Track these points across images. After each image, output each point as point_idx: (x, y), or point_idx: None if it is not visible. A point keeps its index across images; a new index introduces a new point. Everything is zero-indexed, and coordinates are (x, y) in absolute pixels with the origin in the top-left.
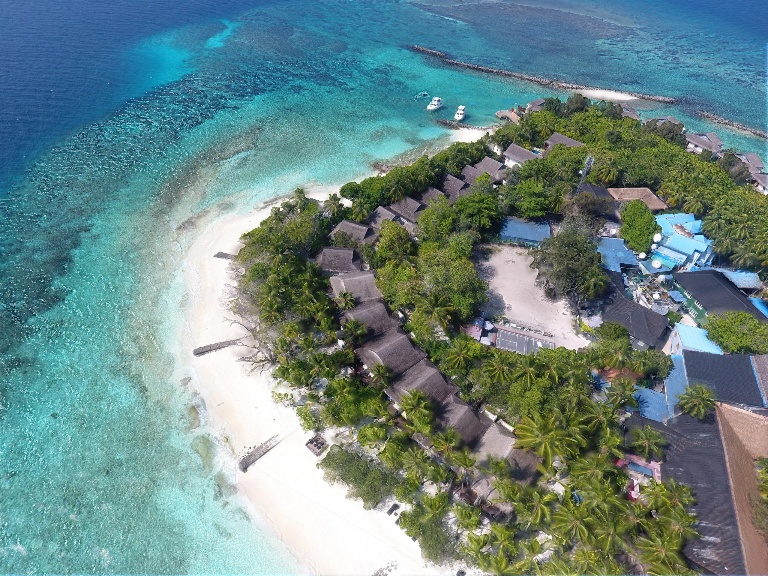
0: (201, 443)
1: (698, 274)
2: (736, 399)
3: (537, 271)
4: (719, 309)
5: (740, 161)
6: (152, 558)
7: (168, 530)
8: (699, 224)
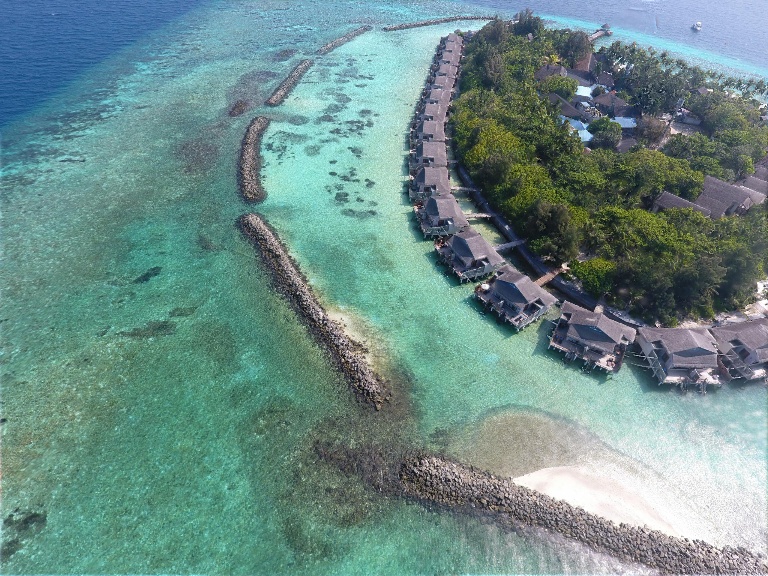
0: (764, 102)
1: None
2: None
3: None
4: None
5: (498, 158)
6: None
7: None
8: None
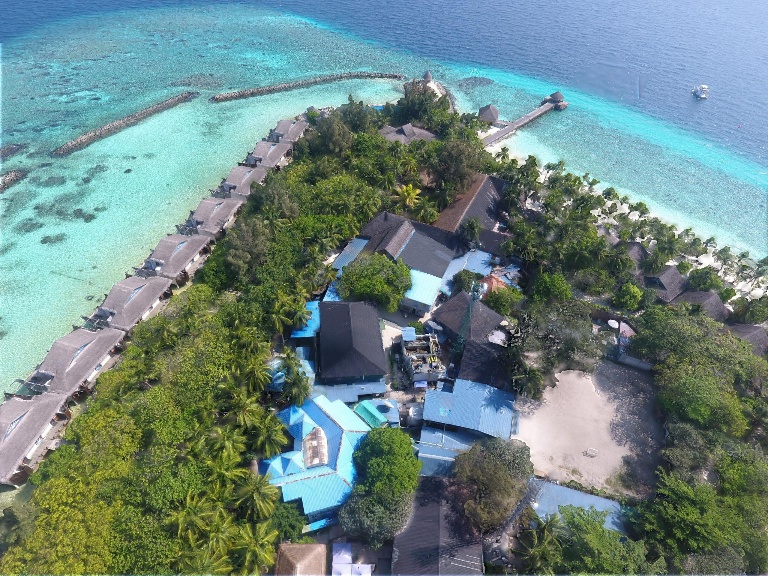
0: None
1: (366, 355)
2: (429, 240)
3: (550, 432)
4: (371, 316)
5: None
6: (760, 242)
7: (763, 250)
8: (277, 461)
